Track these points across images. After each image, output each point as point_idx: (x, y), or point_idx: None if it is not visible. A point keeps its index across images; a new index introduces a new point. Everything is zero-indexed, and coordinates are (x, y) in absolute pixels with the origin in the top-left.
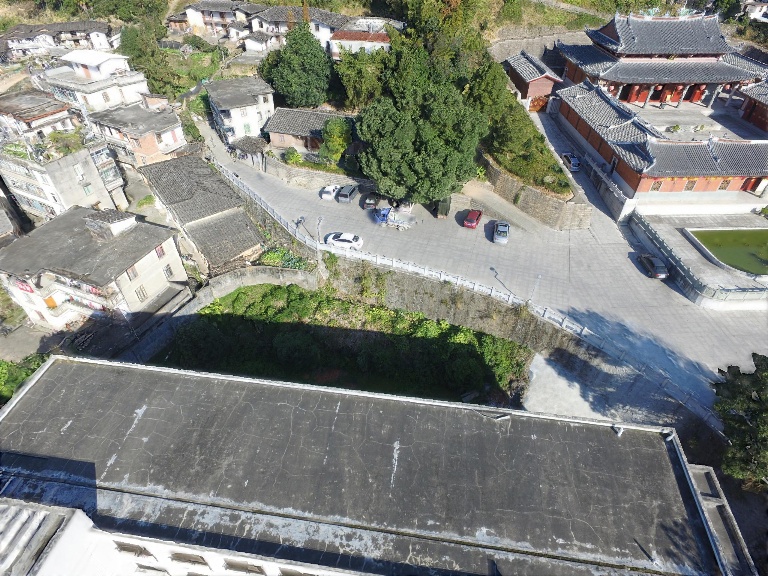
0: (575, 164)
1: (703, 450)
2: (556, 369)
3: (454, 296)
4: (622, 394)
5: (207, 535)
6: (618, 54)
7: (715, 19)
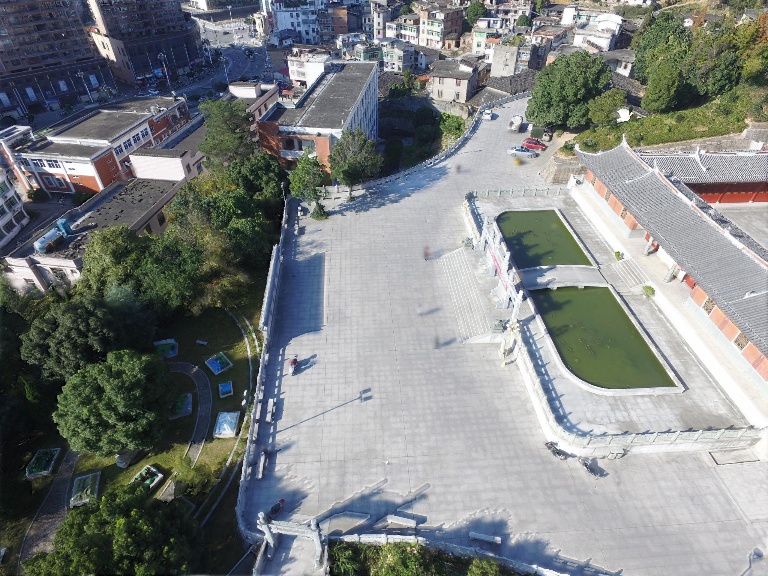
0: None
1: None
2: None
3: None
4: None
5: (320, 82)
6: None
7: None
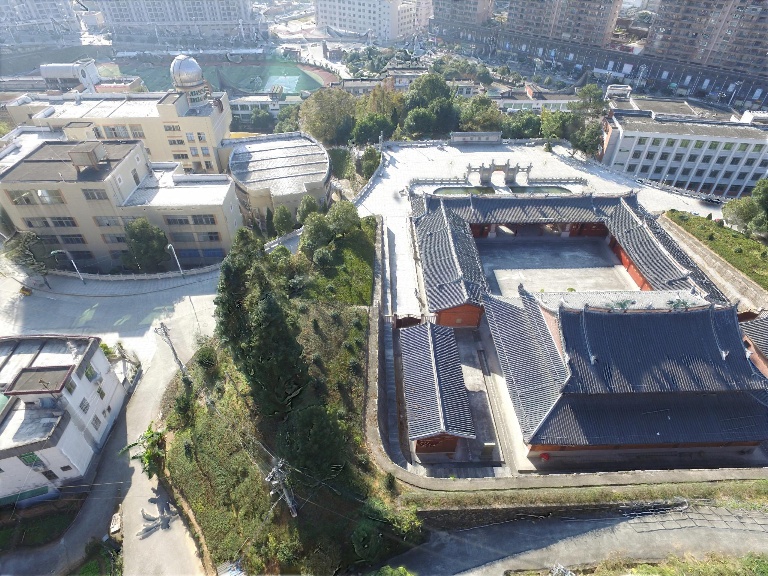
0: None
1: None
2: None
3: None
4: None
5: None
6: None
7: None
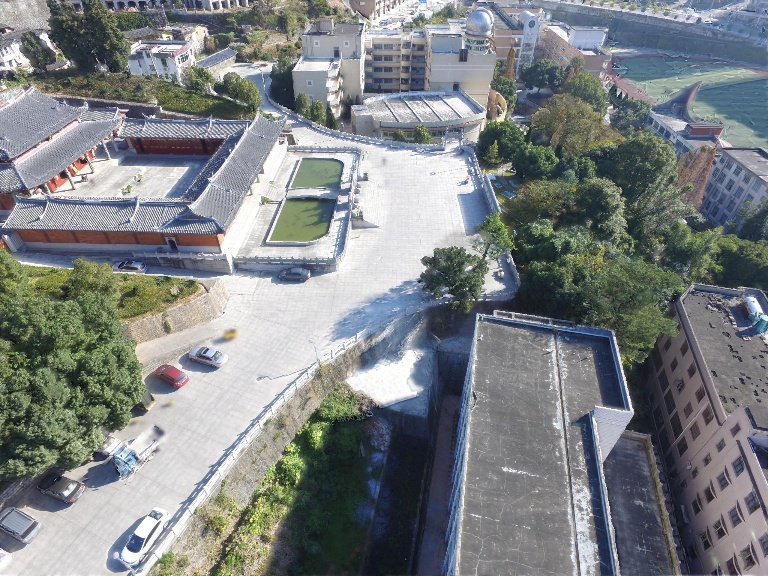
0: (141, 266)
1: (441, 318)
2: (362, 372)
3: (278, 423)
4: (395, 340)
5: None
6: (7, 160)
7: (35, 91)
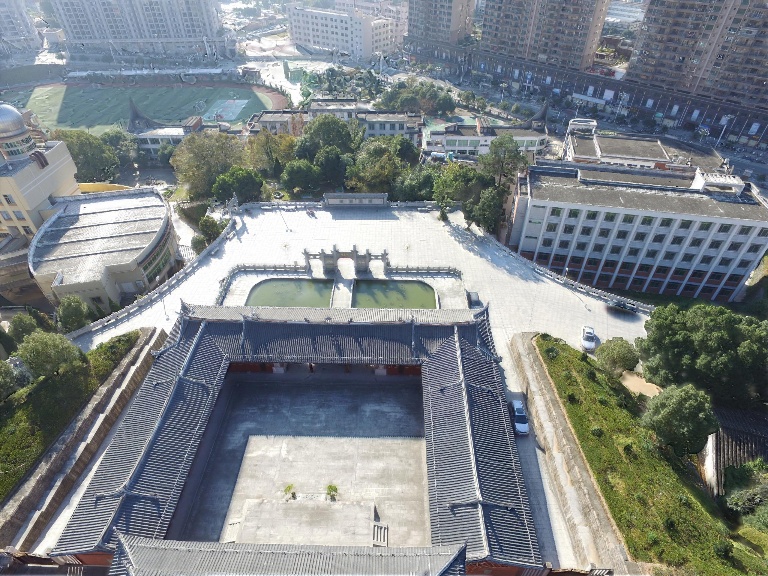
0: None
1: None
2: None
3: None
4: None
5: None
6: None
7: None
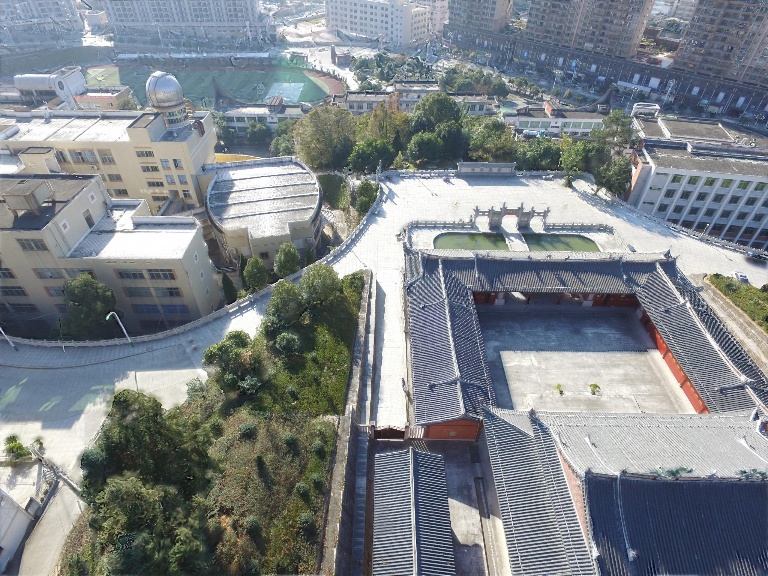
0: None
1: None
2: None
3: None
4: None
5: None
6: None
7: None
